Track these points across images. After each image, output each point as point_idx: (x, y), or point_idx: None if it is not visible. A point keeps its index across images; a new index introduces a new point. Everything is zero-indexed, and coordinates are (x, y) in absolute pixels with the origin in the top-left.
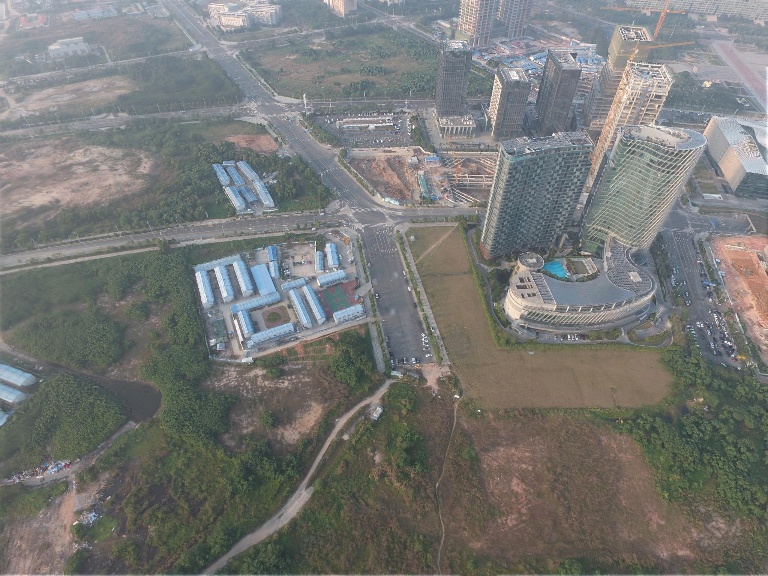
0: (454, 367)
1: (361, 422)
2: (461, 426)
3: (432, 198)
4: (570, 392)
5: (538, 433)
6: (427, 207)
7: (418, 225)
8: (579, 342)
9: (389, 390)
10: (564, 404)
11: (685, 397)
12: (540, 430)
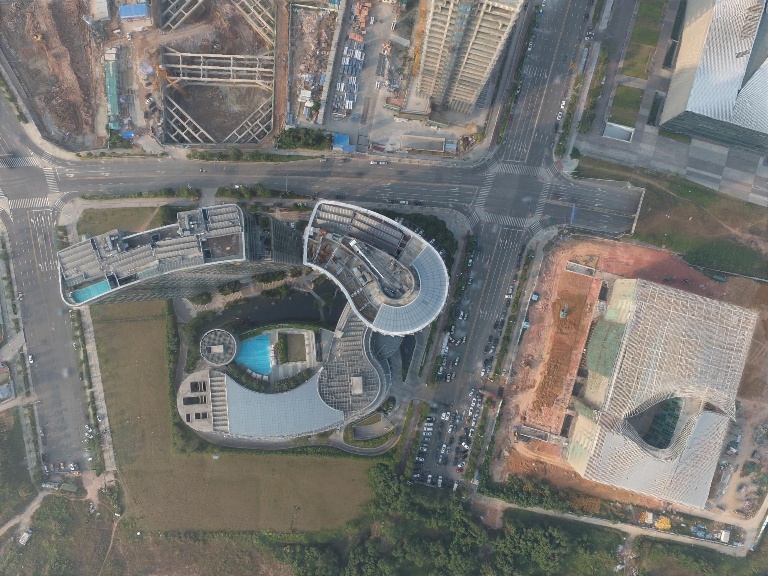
0: (120, 475)
1: (9, 547)
2: (116, 551)
3: (123, 136)
4: (246, 511)
5: (195, 561)
6: (116, 157)
7: (98, 205)
8: (280, 441)
9: (41, 507)
10: (234, 526)
11: (374, 519)
12: (198, 558)
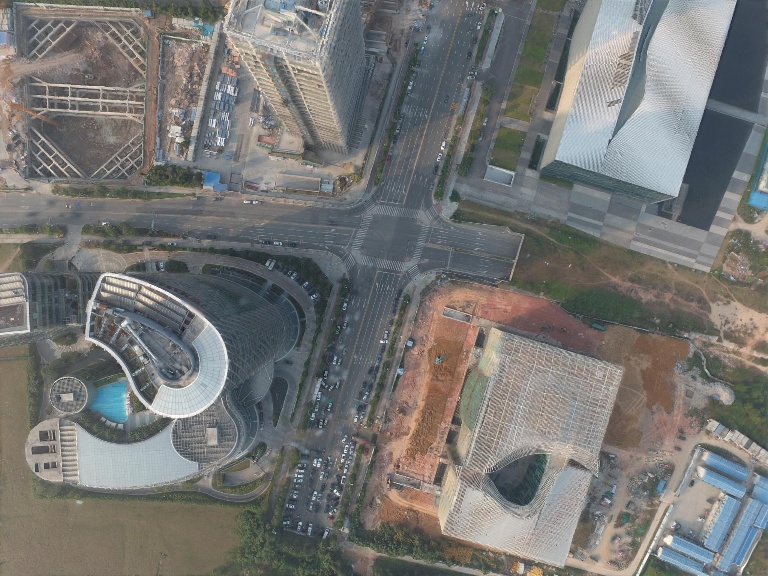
0: None
1: None
2: None
3: None
4: (110, 557)
5: None
6: None
7: None
8: None
9: None
10: (98, 572)
11: (242, 566)
12: None
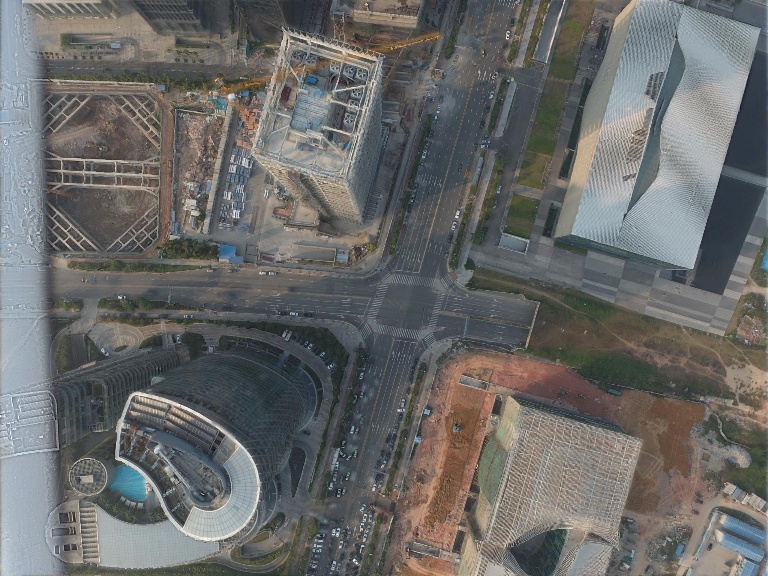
0: None
1: None
2: None
3: None
4: None
5: None
6: None
7: None
8: None
9: None
10: None
11: None
12: None
